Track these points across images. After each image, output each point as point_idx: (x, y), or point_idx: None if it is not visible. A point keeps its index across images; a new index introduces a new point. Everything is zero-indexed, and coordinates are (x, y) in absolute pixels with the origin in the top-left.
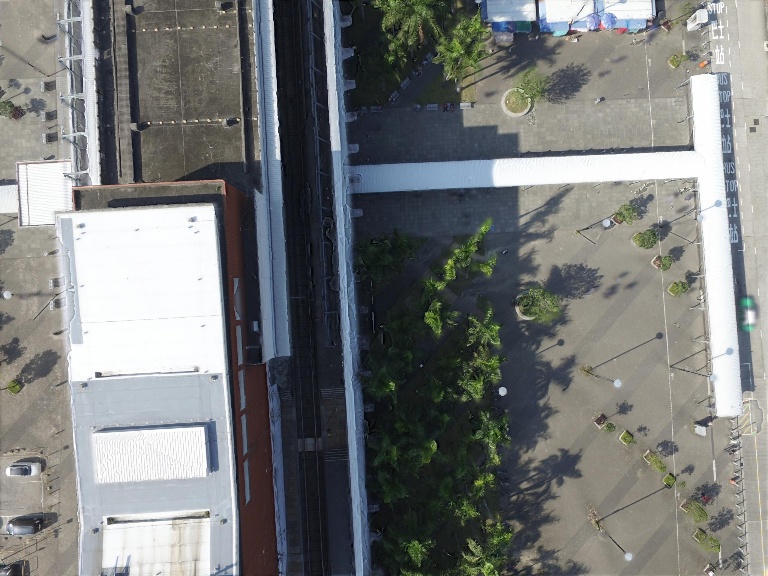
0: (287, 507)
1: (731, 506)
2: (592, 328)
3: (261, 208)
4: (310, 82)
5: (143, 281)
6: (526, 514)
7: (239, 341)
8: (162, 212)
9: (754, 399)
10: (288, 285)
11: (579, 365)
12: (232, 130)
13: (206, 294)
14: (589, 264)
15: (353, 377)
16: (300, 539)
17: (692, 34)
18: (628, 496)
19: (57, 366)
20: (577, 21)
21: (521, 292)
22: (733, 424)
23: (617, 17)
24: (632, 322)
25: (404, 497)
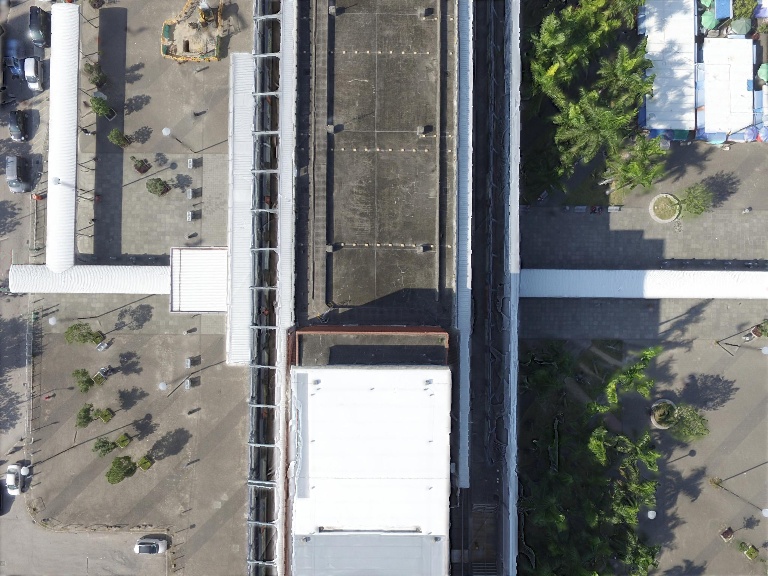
0: None
1: None
2: (725, 440)
3: None
4: (489, 199)
5: (374, 440)
6: None
7: None
8: (399, 373)
9: None
10: None
11: (709, 477)
12: (425, 256)
13: (436, 457)
14: (726, 376)
15: None
16: None
17: None
18: None
19: (188, 445)
20: (735, 133)
21: (657, 401)
22: None
23: None
24: (765, 437)
25: None
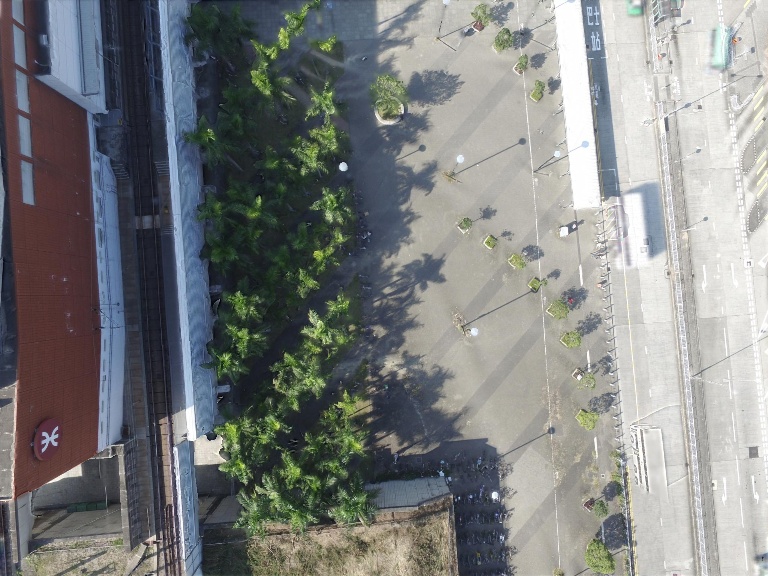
0: (125, 285)
1: (599, 310)
2: (454, 134)
3: None
4: None
5: None
6: (390, 319)
7: (19, 43)
8: None
9: (620, 204)
10: (124, 63)
11: (441, 170)
12: None
13: None
14: (450, 71)
15: (177, 135)
16: (139, 317)
17: None
18: (494, 301)
19: None
20: None
21: None
22: (599, 229)
23: None
24: (494, 128)
25: (234, 259)
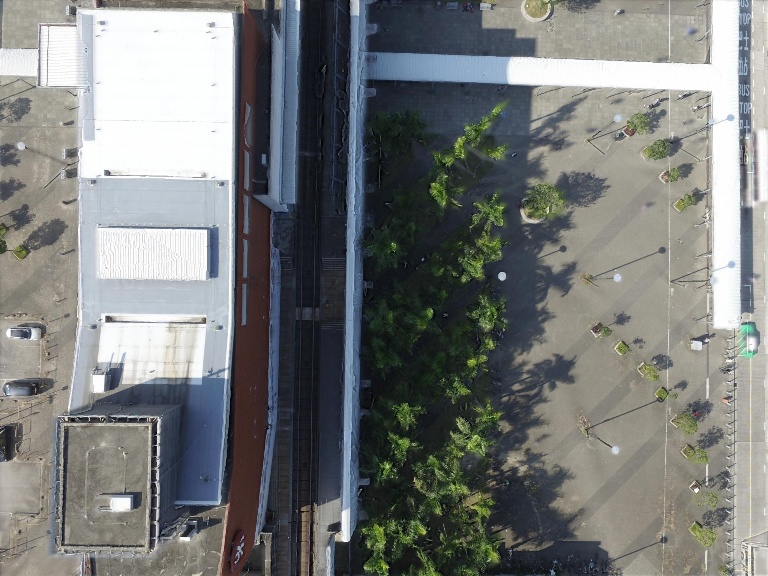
0: (280, 374)
1: (722, 425)
2: (595, 237)
3: (277, 50)
4: None
5: (158, 82)
6: (516, 416)
7: (247, 166)
8: (181, 15)
9: (752, 321)
10: (297, 155)
11: (580, 273)
12: None
13: (218, 100)
14: (597, 174)
15: (355, 241)
16: (291, 406)
17: None
18: (619, 406)
19: (64, 235)
20: None
21: (527, 195)
22: (729, 344)
23: None
24: (636, 234)
25: (397, 365)
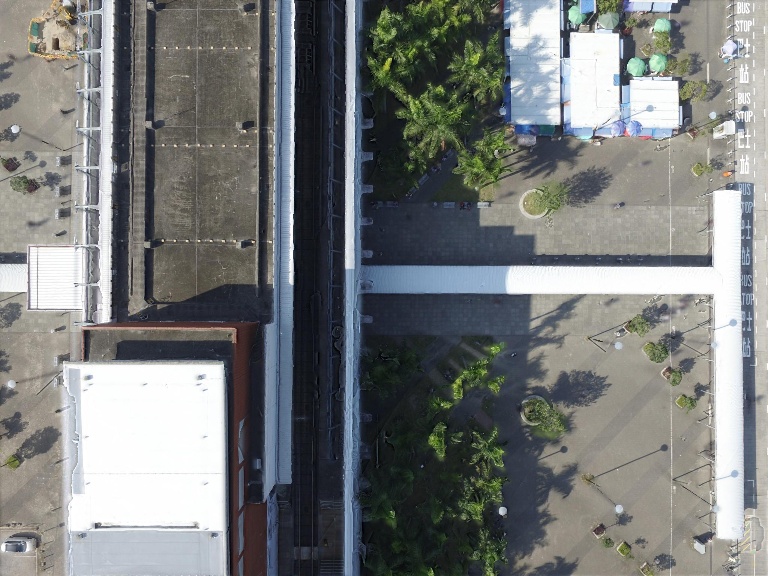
0: None
1: None
2: (597, 436)
3: (271, 339)
4: (328, 194)
5: (148, 436)
6: None
7: (241, 484)
8: (171, 368)
9: (756, 517)
10: (293, 391)
11: (581, 473)
12: (246, 252)
13: (211, 452)
14: (598, 372)
15: (353, 497)
16: None
17: (718, 142)
18: None
19: (58, 443)
20: (602, 127)
21: (527, 397)
22: (733, 541)
23: (643, 125)
24: (637, 433)
25: None
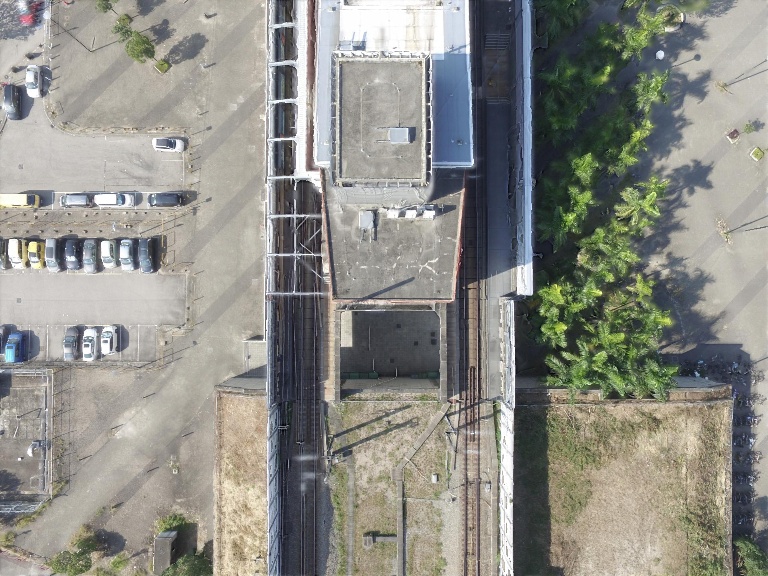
0: None
1: None
2: (728, 46)
3: None
4: None
5: None
6: (657, 220)
7: None
8: None
9: None
10: None
11: (714, 81)
12: None
13: None
14: None
15: (529, 3)
16: None
17: None
18: (756, 211)
19: (204, 49)
20: None
21: (661, 5)
22: None
23: None
24: (767, 44)
25: None
